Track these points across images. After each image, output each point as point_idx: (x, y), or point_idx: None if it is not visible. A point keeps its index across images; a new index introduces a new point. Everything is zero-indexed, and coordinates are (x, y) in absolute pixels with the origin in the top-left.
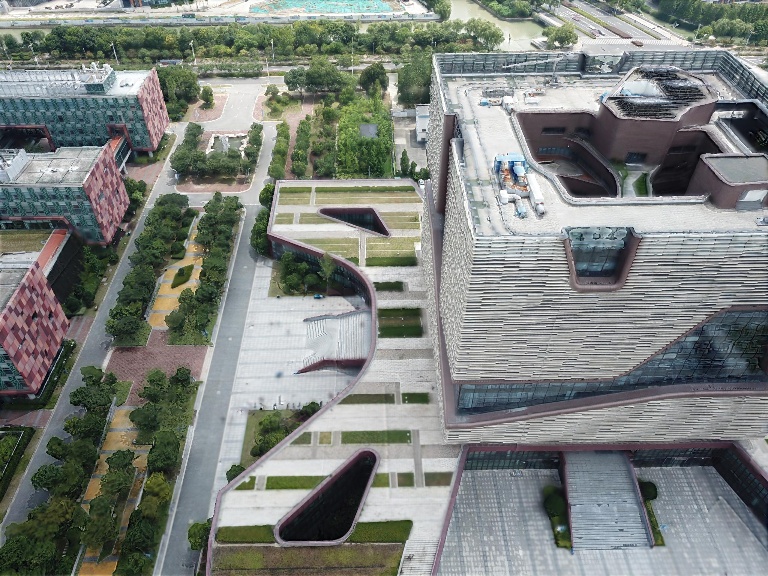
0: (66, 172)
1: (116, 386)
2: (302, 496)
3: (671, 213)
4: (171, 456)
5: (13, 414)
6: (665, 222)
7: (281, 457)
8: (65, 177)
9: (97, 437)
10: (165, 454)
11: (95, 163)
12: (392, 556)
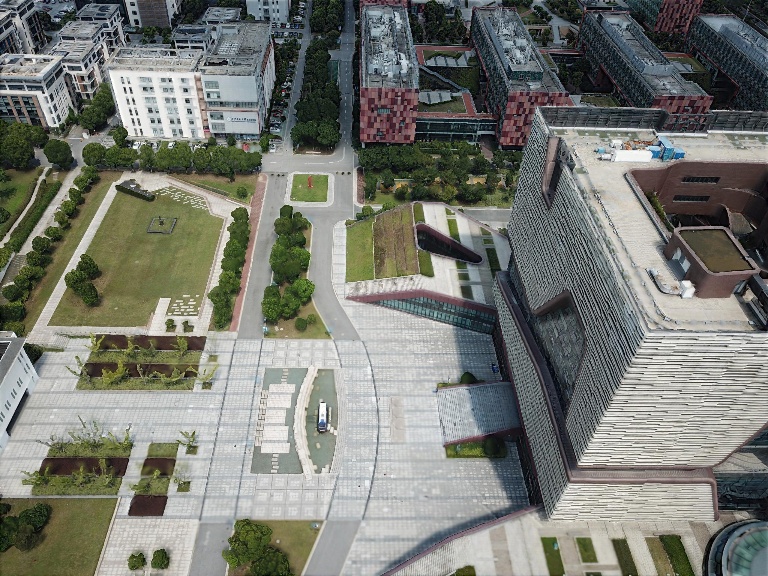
0: (667, 89)
1: (517, 175)
2: (445, 233)
3: (640, 223)
4: (467, 192)
5: (488, 146)
6: (624, 217)
7: (470, 224)
8: (661, 90)
9: (476, 169)
10: (467, 188)
11: (683, 95)
12: (412, 271)
